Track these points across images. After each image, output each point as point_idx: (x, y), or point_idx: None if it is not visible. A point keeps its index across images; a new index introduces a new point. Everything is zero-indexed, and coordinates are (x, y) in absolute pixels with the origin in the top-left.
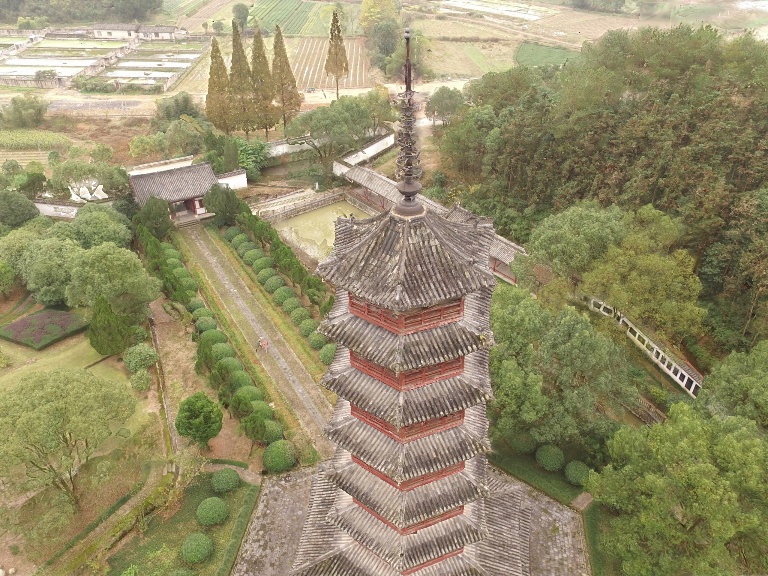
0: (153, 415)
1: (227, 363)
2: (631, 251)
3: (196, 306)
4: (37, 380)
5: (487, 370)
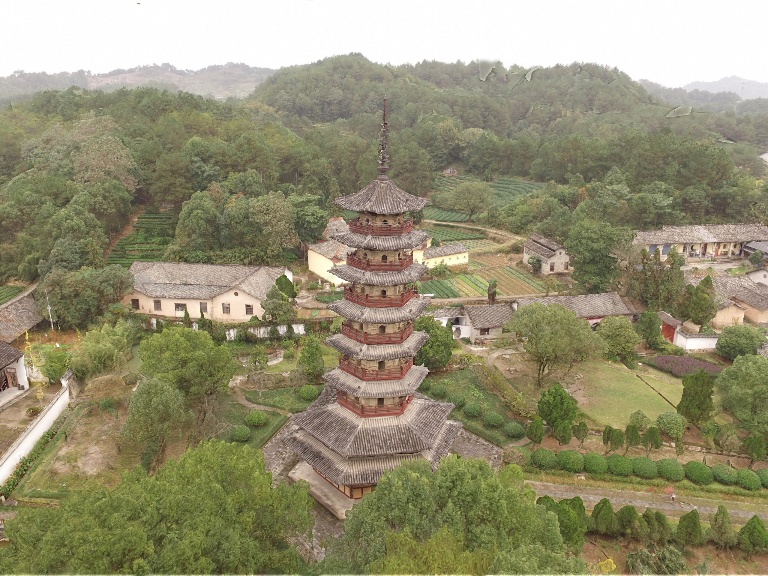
0: (605, 426)
1: (643, 459)
2: (440, 572)
3: (761, 472)
4: (565, 310)
5: (345, 277)
